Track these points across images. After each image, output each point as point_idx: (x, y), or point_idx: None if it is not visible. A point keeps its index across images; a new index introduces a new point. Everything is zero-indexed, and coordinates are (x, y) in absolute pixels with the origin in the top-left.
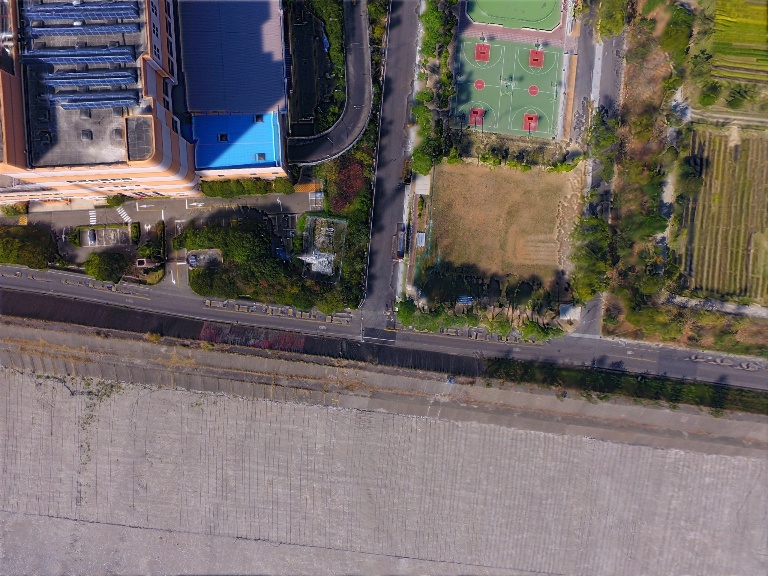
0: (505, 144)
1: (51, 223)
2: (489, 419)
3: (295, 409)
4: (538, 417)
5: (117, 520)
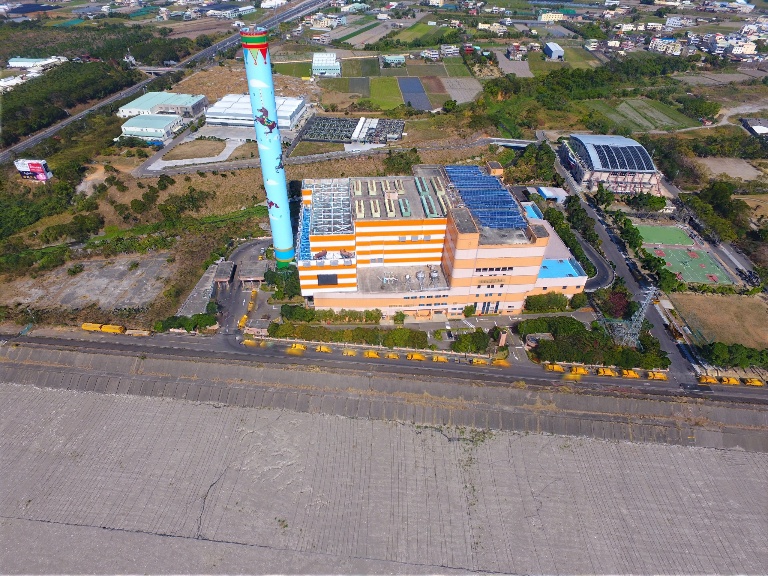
0: None
1: (419, 329)
2: None
3: (657, 449)
4: None
5: (522, 569)
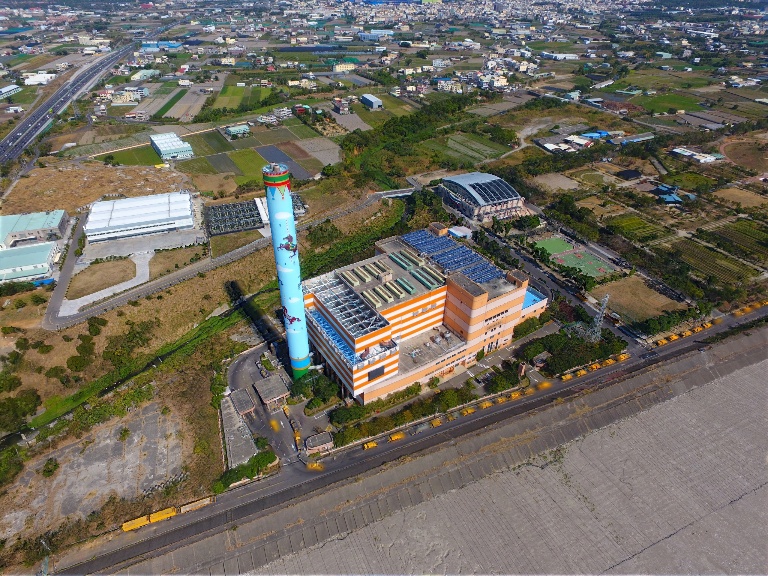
0: (602, 278)
1: (452, 385)
2: (739, 365)
3: (659, 409)
4: (754, 352)
5: (654, 538)
